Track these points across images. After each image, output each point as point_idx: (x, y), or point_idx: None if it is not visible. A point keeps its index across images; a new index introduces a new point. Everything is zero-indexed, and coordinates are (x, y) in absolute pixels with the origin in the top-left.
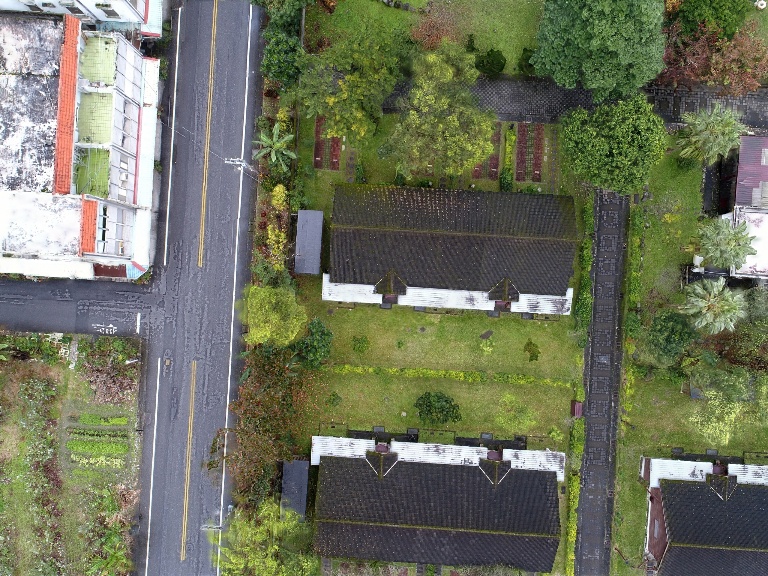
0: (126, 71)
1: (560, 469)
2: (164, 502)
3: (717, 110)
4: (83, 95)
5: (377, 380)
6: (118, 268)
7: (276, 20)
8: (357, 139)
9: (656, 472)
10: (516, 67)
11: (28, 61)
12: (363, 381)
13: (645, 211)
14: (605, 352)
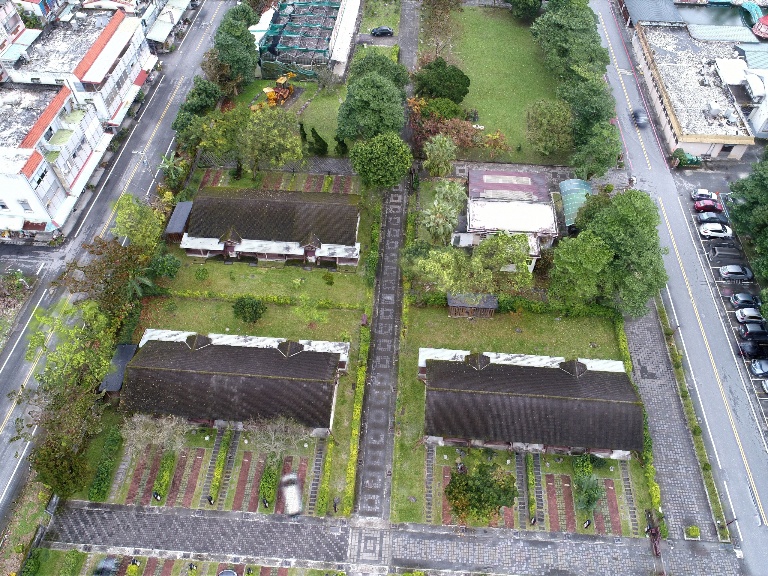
0: (90, 126)
1: (344, 353)
2: (3, 388)
3: (438, 138)
4: (59, 130)
5: (211, 306)
6: (41, 225)
7: (186, 107)
8: (219, 149)
9: (424, 356)
10: (335, 150)
11: (34, 104)
12: (200, 307)
13: (418, 216)
14: (390, 293)
